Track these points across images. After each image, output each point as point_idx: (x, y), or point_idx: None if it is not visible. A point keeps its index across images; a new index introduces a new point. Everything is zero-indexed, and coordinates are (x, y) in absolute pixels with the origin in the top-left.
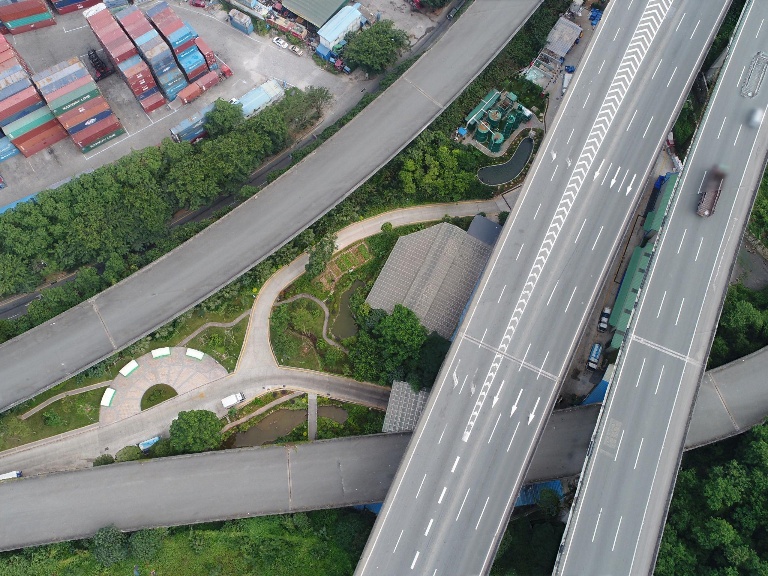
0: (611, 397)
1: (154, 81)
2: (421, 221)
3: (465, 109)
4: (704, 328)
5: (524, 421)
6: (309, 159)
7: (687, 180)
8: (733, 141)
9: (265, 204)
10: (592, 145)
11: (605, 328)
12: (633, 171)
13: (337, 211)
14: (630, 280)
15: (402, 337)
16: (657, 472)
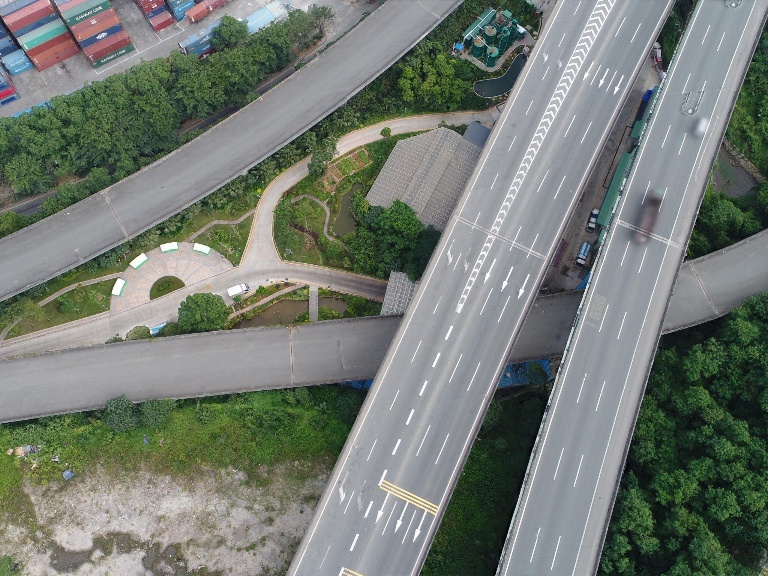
0: (597, 275)
1: None
2: (419, 130)
3: (462, 25)
4: (686, 215)
5: (514, 295)
6: (312, 65)
7: (672, 81)
8: (716, 47)
9: (270, 106)
10: (582, 48)
11: (593, 228)
12: (621, 73)
13: (338, 117)
14: (618, 183)
15: (400, 226)
16: (639, 342)
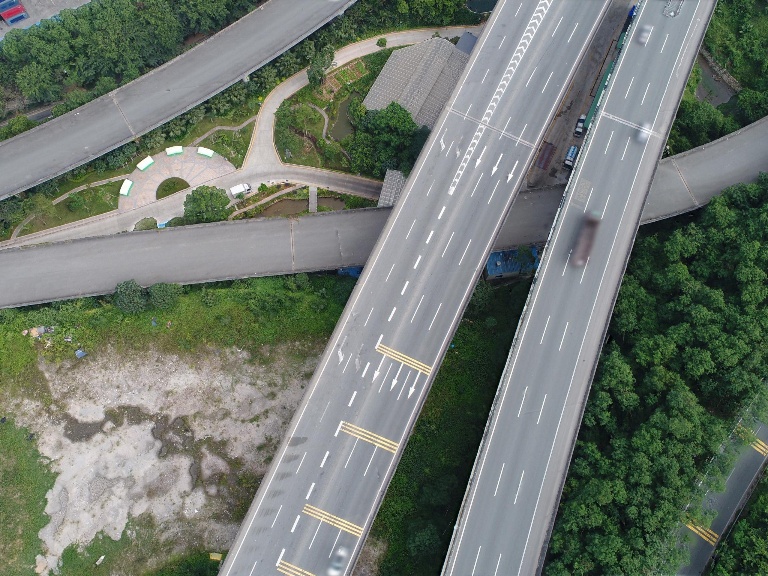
0: (582, 161)
1: None
2: (413, 43)
3: None
4: (667, 108)
5: (504, 179)
6: None
7: None
8: None
9: (270, 15)
10: None
11: (581, 132)
12: None
13: (336, 28)
14: None
15: (395, 123)
16: (622, 222)
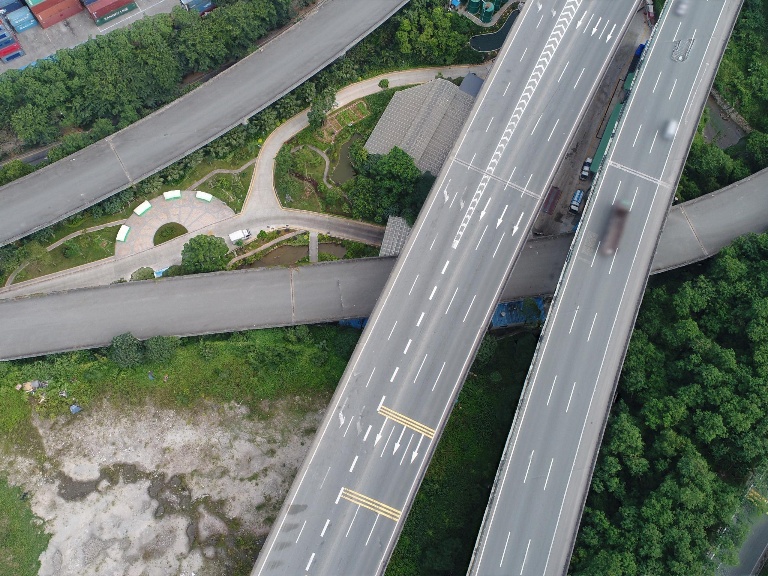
0: (589, 213)
1: None
2: (416, 83)
3: None
4: (676, 156)
5: (509, 232)
6: (312, 17)
7: (663, 30)
8: None
9: (270, 56)
10: None
11: (587, 176)
12: (613, 21)
13: (337, 69)
14: (610, 132)
15: (397, 170)
16: (630, 277)
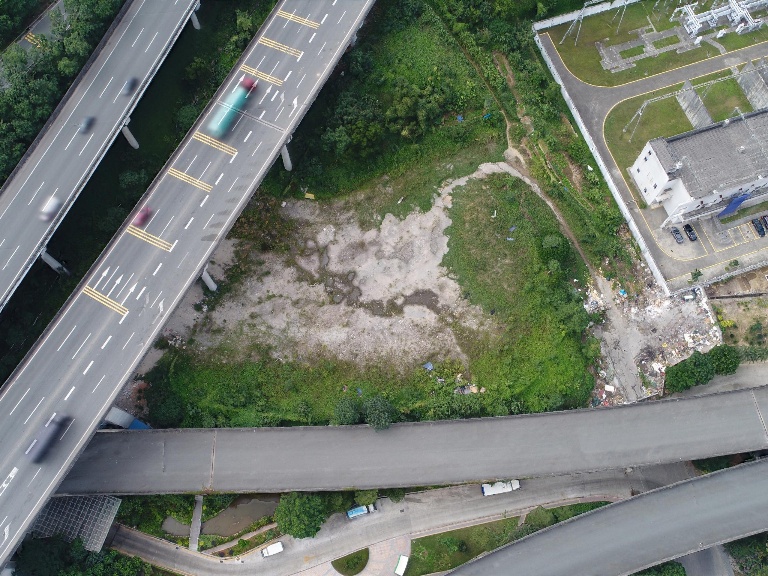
0: None
1: None
2: None
3: None
4: None
5: None
6: None
7: None
8: None
9: None
10: None
11: None
12: None
13: None
14: None
15: None
16: None
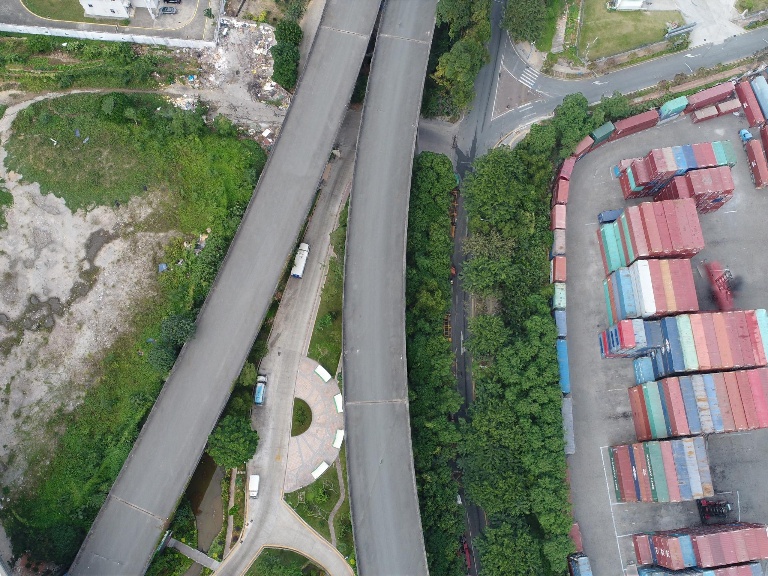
0: None
1: (663, 565)
2: None
3: None
4: None
5: None
6: None
7: None
8: None
9: None
10: None
11: None
12: None
13: None
14: None
15: None
16: None
